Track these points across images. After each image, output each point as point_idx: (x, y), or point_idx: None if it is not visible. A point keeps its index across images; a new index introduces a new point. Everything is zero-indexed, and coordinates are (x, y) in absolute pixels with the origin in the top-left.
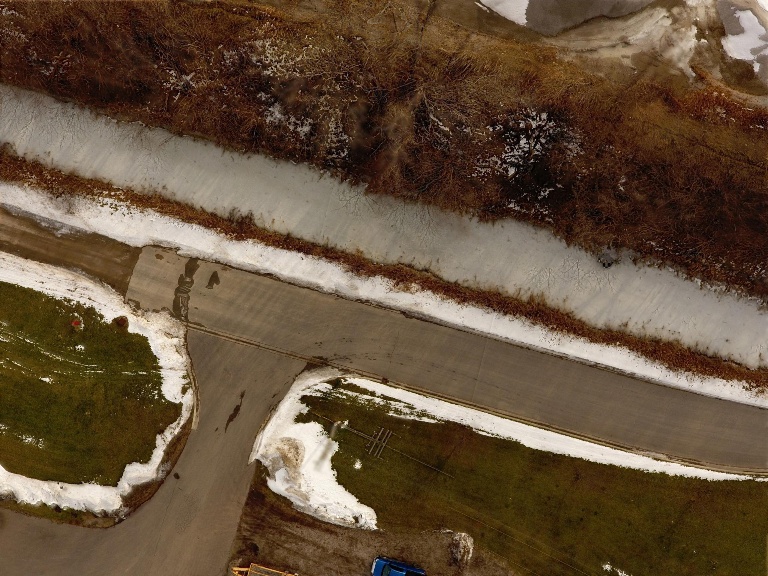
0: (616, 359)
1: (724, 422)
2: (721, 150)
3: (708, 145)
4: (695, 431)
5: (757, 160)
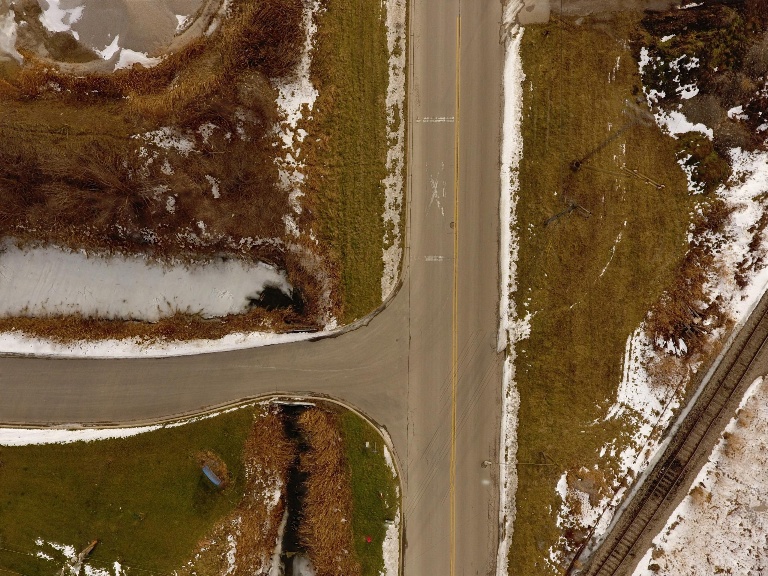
0: (11, 344)
1: (126, 380)
2: (21, 126)
3: (5, 125)
4: (101, 394)
5: (57, 128)
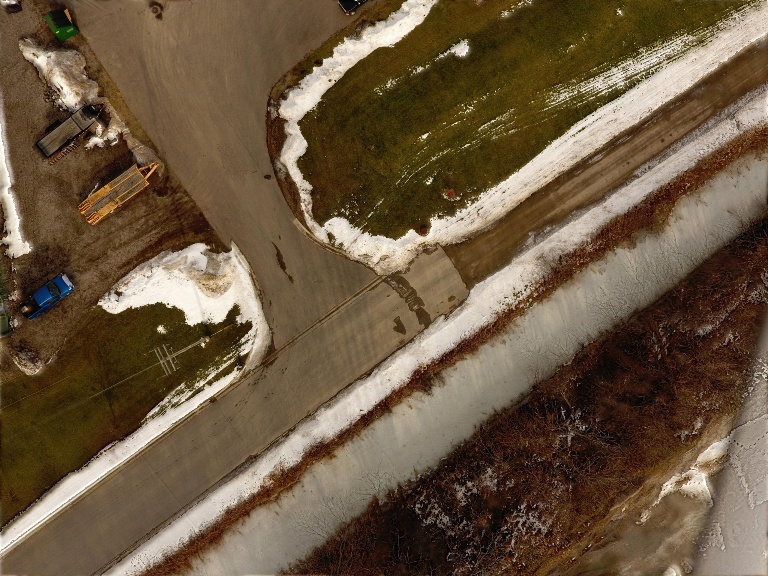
0: None
1: None
2: None
3: None
4: None
5: None
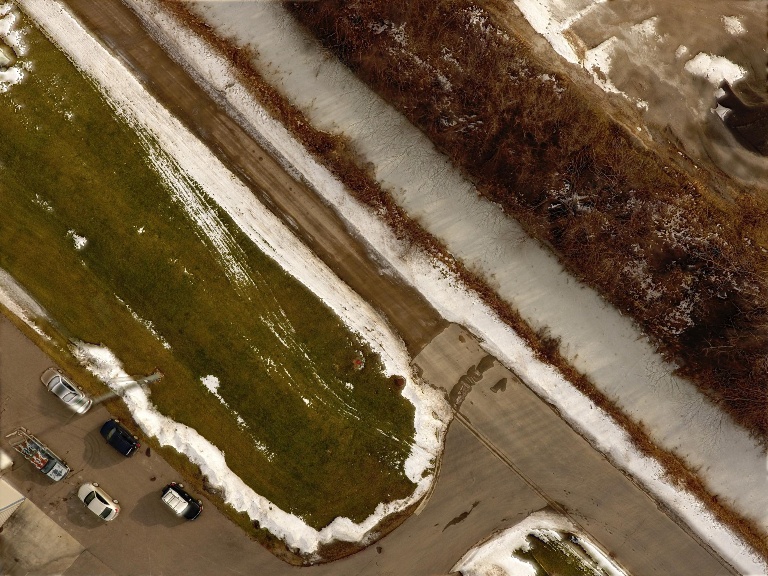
0: None
1: None
2: None
3: None
4: None
5: None
